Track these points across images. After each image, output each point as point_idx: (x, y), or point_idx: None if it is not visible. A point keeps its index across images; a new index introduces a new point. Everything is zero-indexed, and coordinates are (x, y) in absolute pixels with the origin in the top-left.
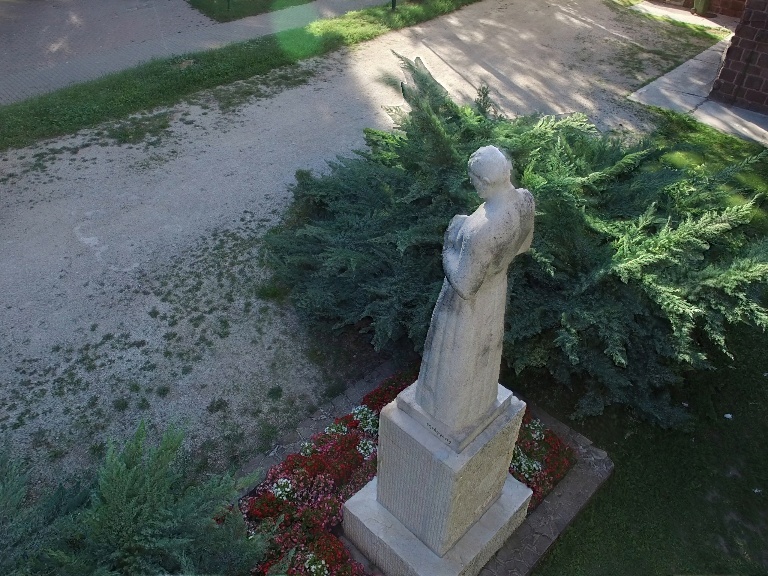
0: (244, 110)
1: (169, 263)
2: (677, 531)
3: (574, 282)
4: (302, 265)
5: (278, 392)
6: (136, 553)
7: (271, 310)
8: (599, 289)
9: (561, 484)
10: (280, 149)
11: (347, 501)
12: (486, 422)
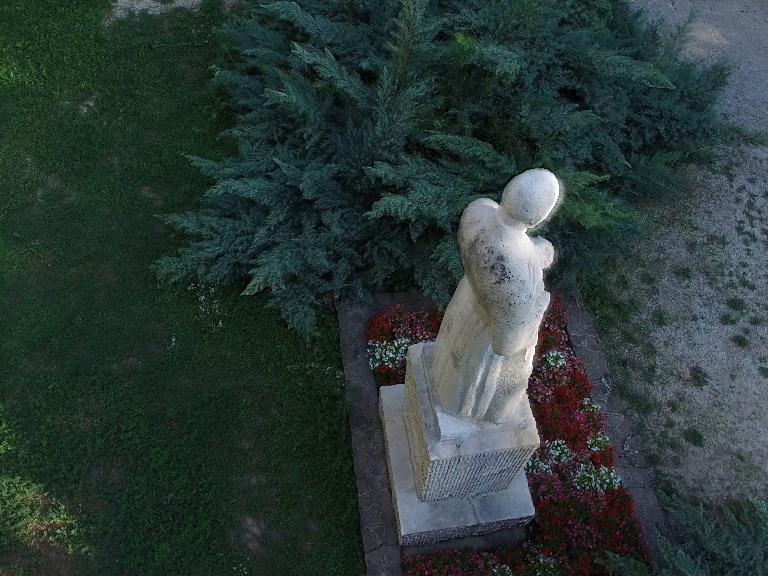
0: None
1: None
2: None
3: None
4: None
5: (694, 439)
6: None
7: None
8: None
9: None
10: None
11: None
12: None
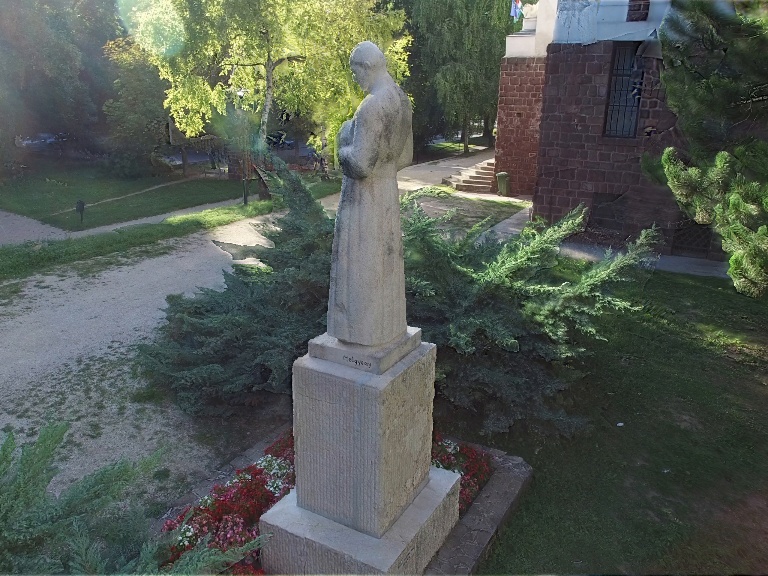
0: (105, 275)
1: (25, 388)
2: (608, 513)
3: (454, 310)
4: (181, 364)
5: (165, 472)
6: (5, 552)
7: (149, 410)
8: (478, 308)
9: (486, 488)
10: (146, 297)
11: (263, 514)
12: (402, 350)
